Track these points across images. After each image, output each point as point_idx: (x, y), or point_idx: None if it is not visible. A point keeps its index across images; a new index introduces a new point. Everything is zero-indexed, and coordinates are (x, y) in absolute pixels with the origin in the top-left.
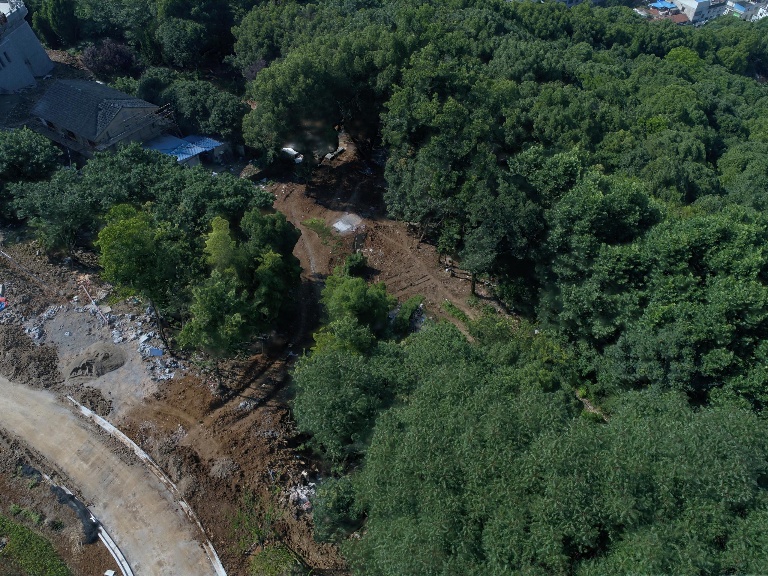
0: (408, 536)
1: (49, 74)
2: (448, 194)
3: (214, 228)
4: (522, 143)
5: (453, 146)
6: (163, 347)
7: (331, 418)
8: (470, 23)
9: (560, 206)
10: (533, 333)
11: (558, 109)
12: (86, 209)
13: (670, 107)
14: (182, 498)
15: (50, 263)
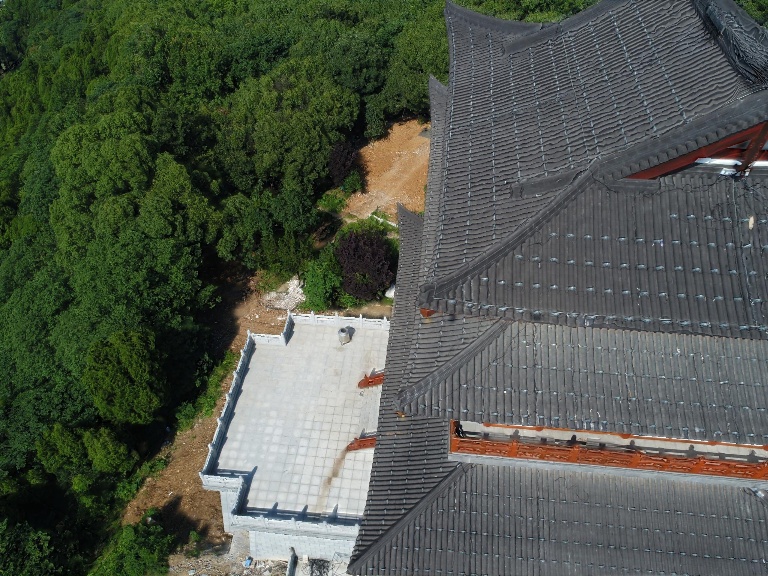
0: None
1: None
2: None
3: None
4: None
5: None
6: None
7: None
8: (311, 8)
9: None
10: None
11: None
12: None
13: None
14: None
15: None
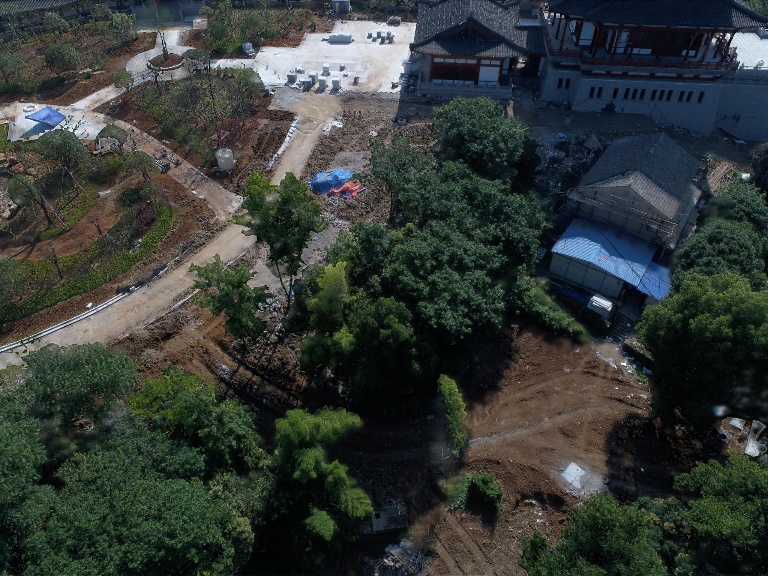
0: None
1: (746, 141)
2: None
3: None
4: None
5: None
6: None
7: (32, 364)
8: None
9: None
10: None
11: None
12: None
13: None
14: None
15: (394, 207)
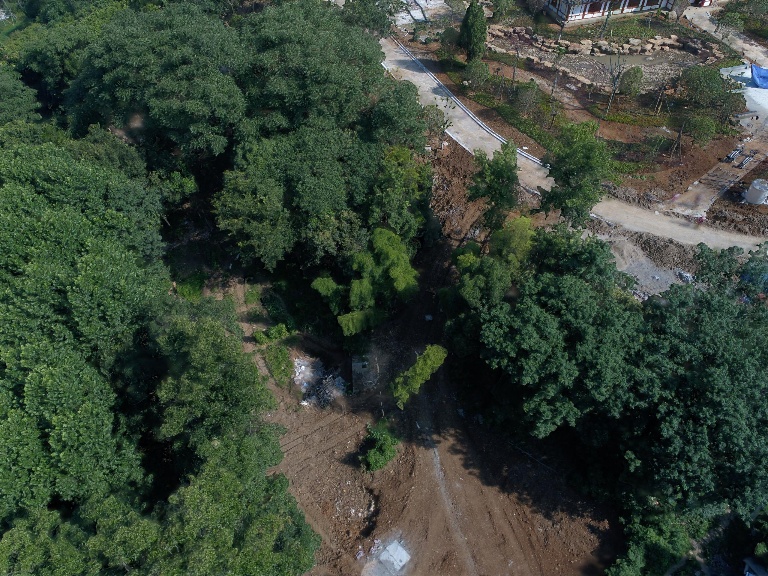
0: None
1: None
2: None
3: None
4: None
5: None
6: None
7: None
8: None
9: None
10: (231, 222)
11: None
12: None
13: None
14: None
15: None
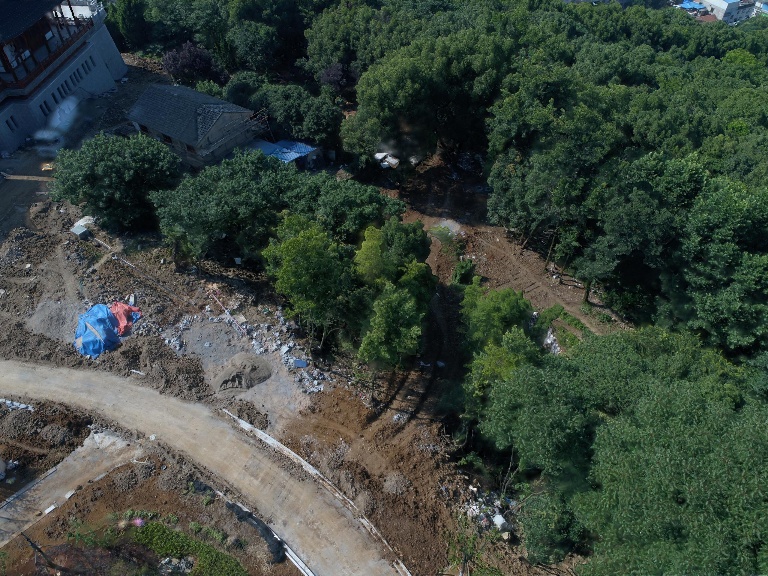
0: (678, 562)
1: (125, 78)
2: (570, 201)
3: (367, 238)
4: (622, 148)
5: (582, 153)
6: (306, 358)
7: (552, 437)
8: (546, 26)
9: (695, 214)
10: None
11: (657, 114)
12: (221, 218)
13: (749, 111)
14: (362, 515)
15: (177, 272)
